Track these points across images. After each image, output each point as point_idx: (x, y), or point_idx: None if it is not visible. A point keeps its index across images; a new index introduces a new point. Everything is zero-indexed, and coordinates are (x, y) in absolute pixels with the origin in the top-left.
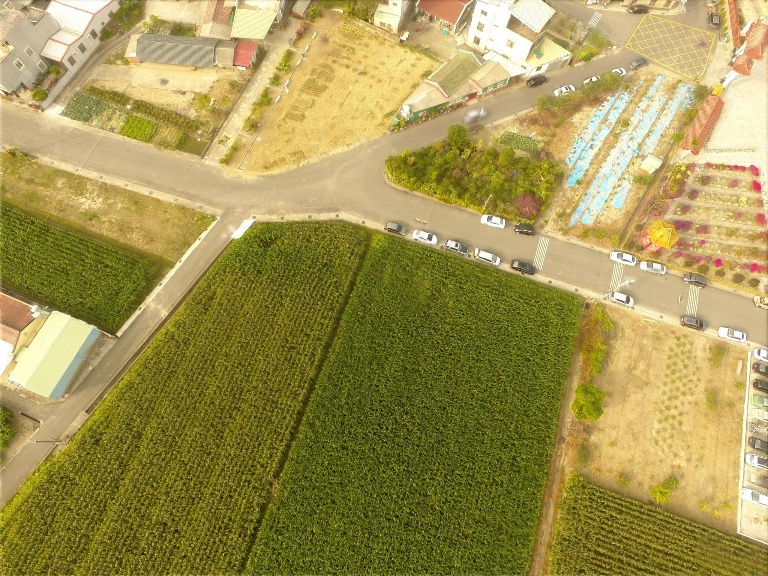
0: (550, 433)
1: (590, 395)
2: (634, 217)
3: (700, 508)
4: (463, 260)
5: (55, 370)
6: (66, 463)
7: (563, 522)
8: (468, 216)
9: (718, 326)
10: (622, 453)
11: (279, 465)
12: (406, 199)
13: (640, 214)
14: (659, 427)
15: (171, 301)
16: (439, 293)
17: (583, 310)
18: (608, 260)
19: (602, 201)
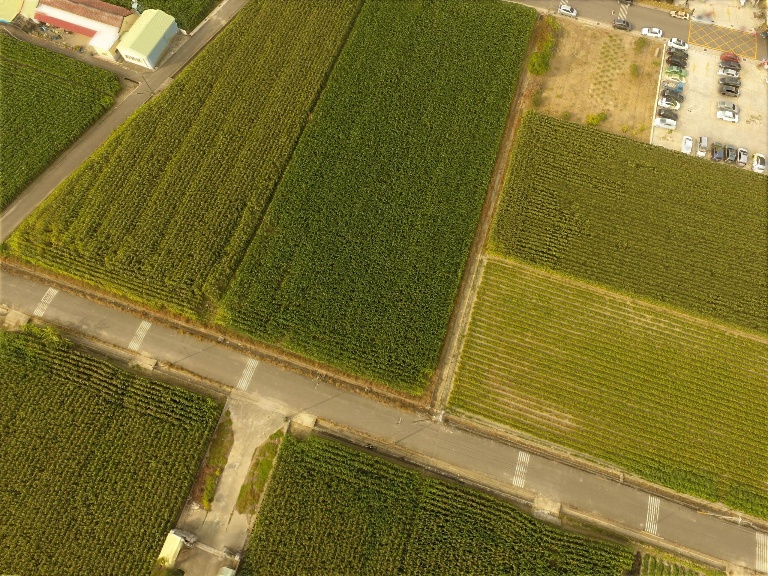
0: (511, 86)
1: None
2: None
3: (623, 132)
4: None
5: (150, 41)
6: (161, 100)
7: (520, 132)
8: None
9: (641, 28)
10: (566, 102)
11: (313, 104)
12: None
13: None
14: (594, 88)
15: (228, 15)
16: (428, 7)
17: (538, 20)
18: None
19: None
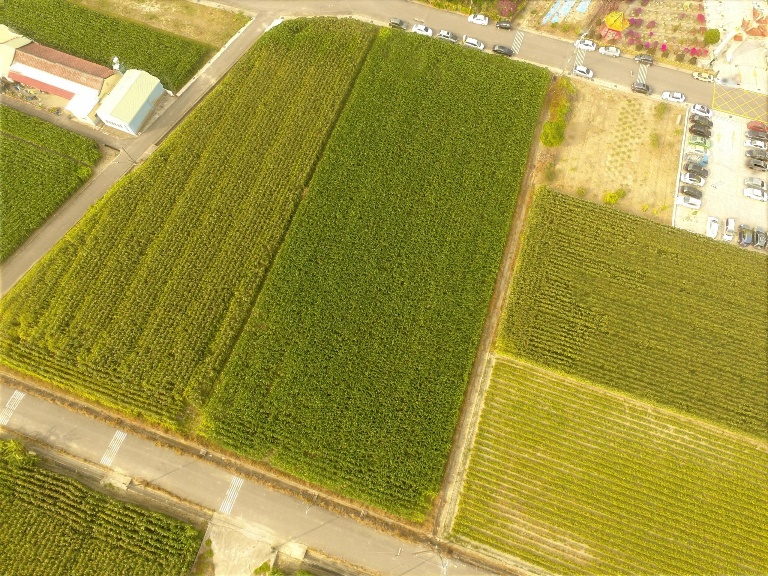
0: (523, 158)
1: (554, 123)
2: (595, 19)
3: (643, 211)
4: (453, 44)
5: (132, 106)
6: (143, 172)
7: (532, 213)
8: (458, 17)
9: (662, 92)
10: (581, 176)
11: (308, 177)
12: (407, 5)
13: (600, 14)
14: (612, 159)
15: (218, 73)
16: (434, 67)
17: (551, 81)
18: (573, 47)
19: (569, 7)
